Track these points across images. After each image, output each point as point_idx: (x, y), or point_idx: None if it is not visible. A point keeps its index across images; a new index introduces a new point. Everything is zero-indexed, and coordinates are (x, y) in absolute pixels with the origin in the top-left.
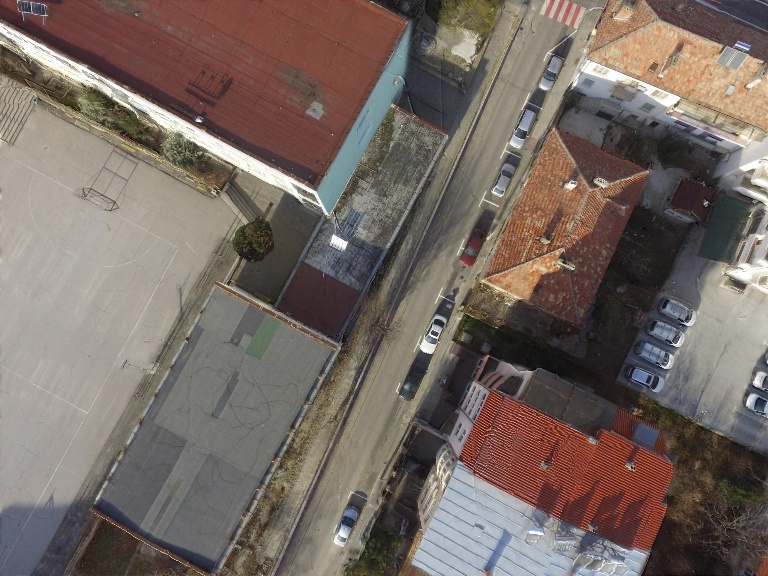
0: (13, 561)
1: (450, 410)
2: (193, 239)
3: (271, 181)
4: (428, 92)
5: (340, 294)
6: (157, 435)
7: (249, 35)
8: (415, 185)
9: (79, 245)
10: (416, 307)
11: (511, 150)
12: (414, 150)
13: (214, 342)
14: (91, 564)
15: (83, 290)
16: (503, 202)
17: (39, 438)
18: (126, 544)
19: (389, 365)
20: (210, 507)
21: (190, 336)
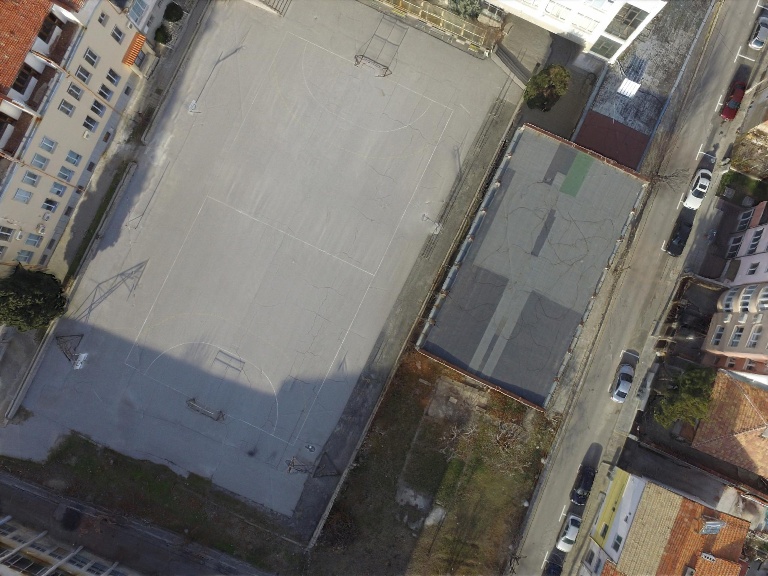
0: (310, 425)
1: (721, 262)
2: (467, 101)
3: (567, 25)
4: None
5: (630, 139)
6: (477, 276)
7: None
8: (695, 30)
9: (355, 112)
10: (677, 165)
11: (764, 4)
12: None
13: (527, 183)
14: (381, 428)
15: (362, 155)
16: (759, 56)
17: (328, 303)
18: (413, 407)
19: (653, 223)
20: (536, 344)
21: (501, 179)
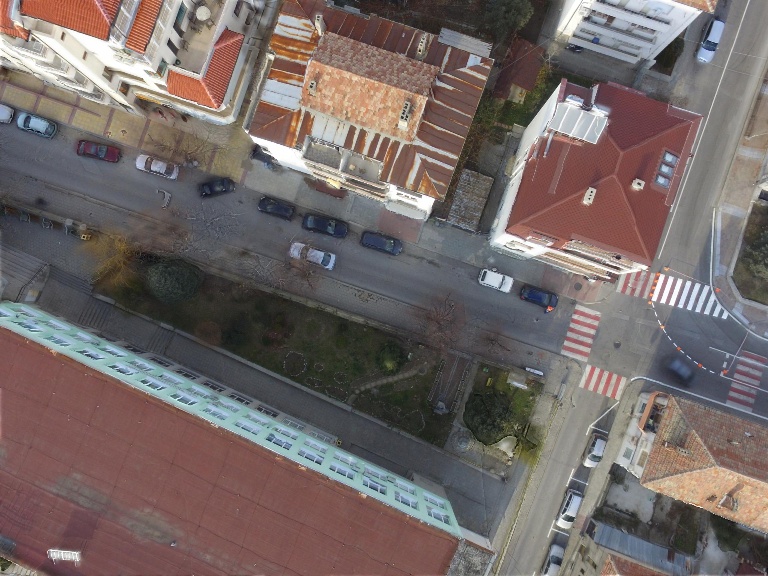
0: None
1: None
2: None
3: None
4: (469, 486)
5: None
6: None
7: (293, 561)
8: None
9: None
10: None
11: (558, 528)
12: (462, 573)
13: None
14: None
15: None
16: None
17: None
18: None
19: None
20: None
21: None
